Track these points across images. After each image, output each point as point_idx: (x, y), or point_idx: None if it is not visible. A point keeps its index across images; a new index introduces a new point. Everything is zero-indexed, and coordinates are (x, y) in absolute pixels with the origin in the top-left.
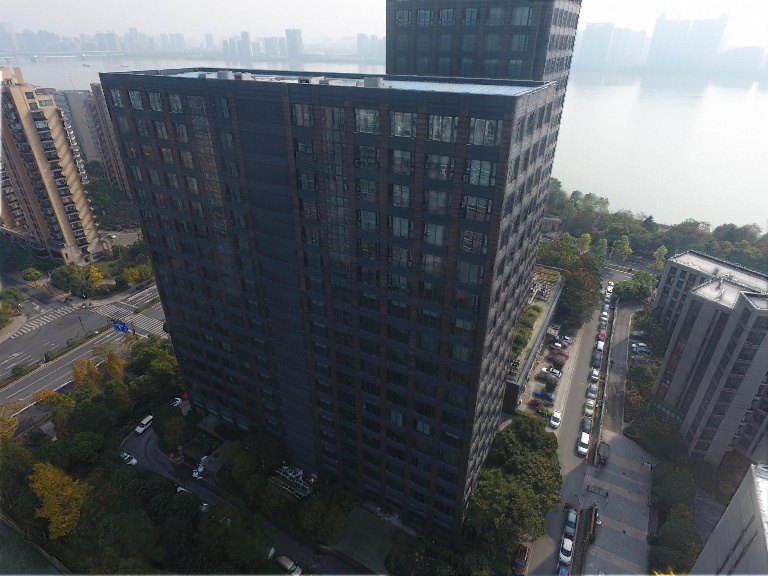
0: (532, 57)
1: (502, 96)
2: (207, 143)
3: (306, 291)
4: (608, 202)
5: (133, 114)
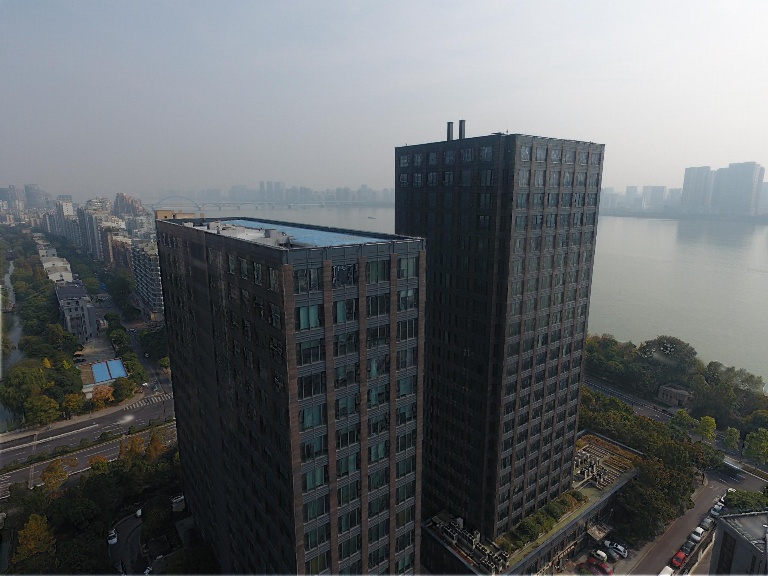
0: (496, 214)
1: (275, 249)
2: None
3: (219, 408)
4: (762, 382)
5: None
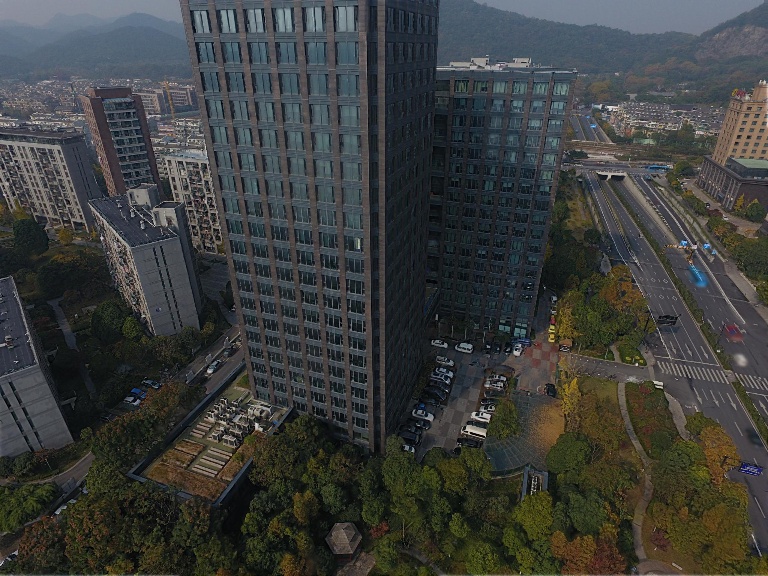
0: None
1: None
2: None
3: None
4: None
5: None
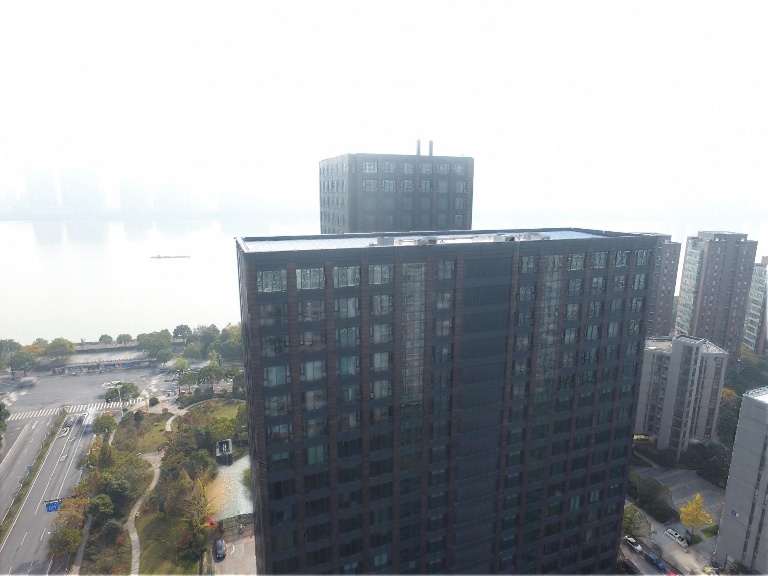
0: None
1: (653, 236)
2: (417, 308)
3: (508, 424)
4: None
5: (300, 297)
